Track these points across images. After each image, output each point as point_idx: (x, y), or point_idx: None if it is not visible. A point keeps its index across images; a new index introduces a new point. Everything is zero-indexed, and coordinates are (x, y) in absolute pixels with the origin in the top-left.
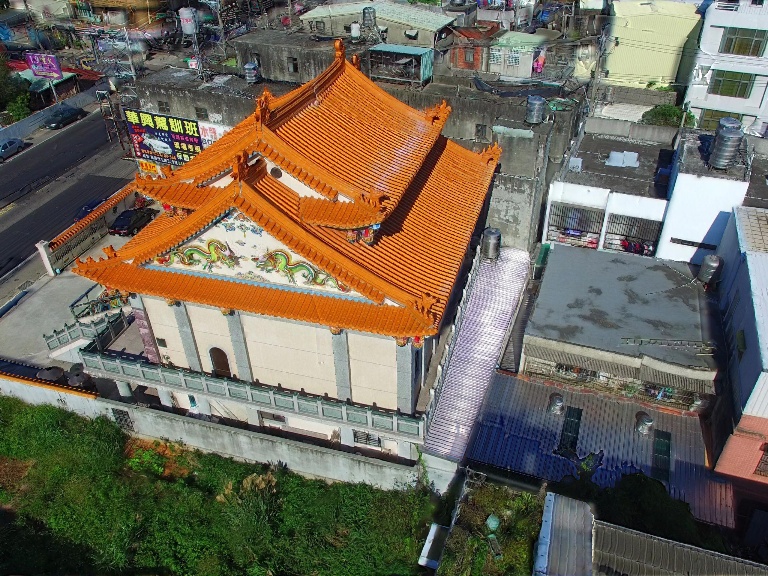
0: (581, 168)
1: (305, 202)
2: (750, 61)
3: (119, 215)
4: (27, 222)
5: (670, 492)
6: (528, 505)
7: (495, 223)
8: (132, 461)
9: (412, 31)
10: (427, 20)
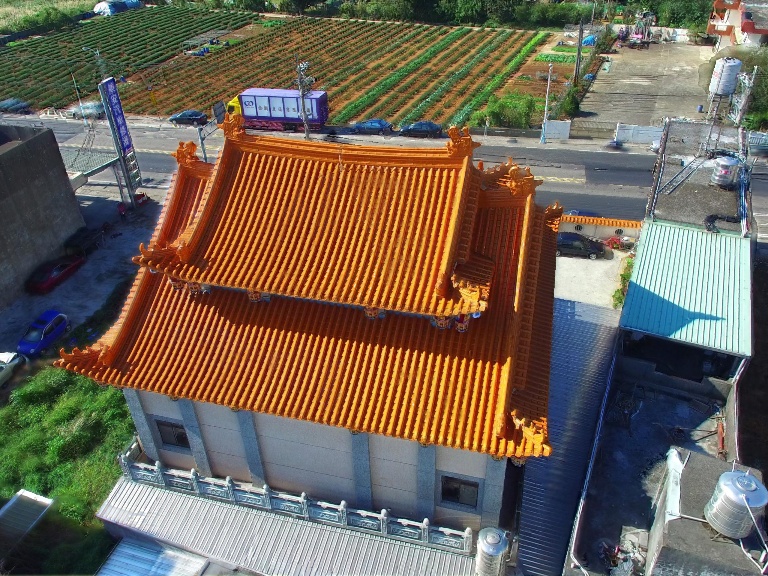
0: None
1: None
2: None
3: None
4: (556, 196)
5: None
6: None
7: None
8: None
9: None
10: None
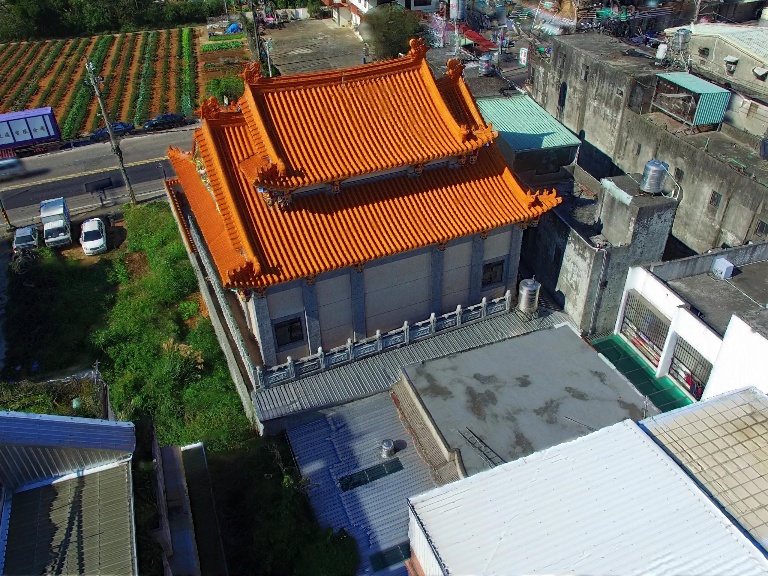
0: (729, 276)
1: (257, 155)
2: None
3: None
4: None
5: None
6: None
7: (564, 283)
8: (184, 304)
9: (762, 69)
10: None
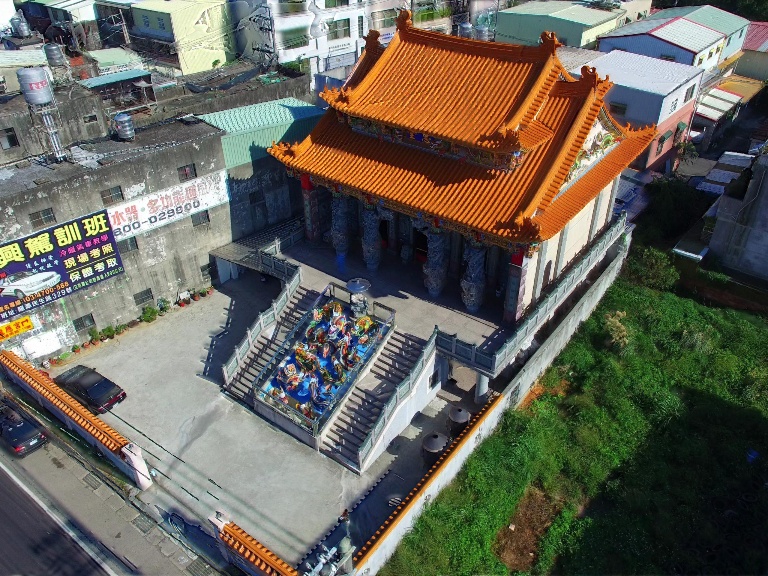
0: None
1: None
2: (352, 7)
3: (84, 388)
4: None
5: None
6: None
7: None
8: None
9: None
10: (35, 57)
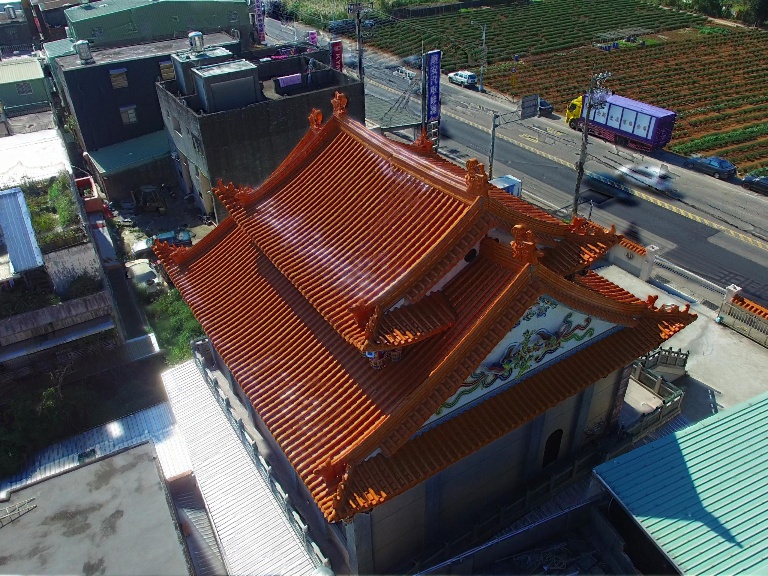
0: None
1: None
2: None
3: None
4: None
5: None
6: (46, 237)
7: None
8: None
9: None
10: None
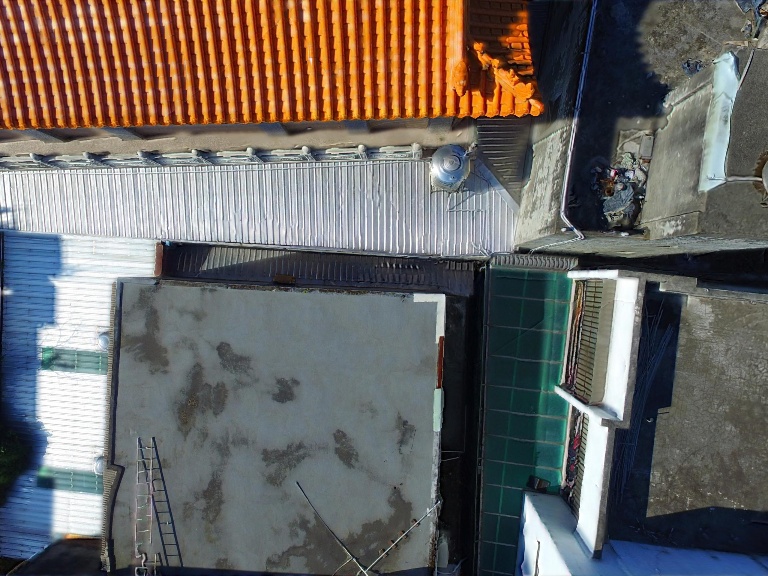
0: None
1: None
2: None
3: None
4: None
5: (24, 487)
6: None
7: (537, 162)
8: None
9: None
10: None
